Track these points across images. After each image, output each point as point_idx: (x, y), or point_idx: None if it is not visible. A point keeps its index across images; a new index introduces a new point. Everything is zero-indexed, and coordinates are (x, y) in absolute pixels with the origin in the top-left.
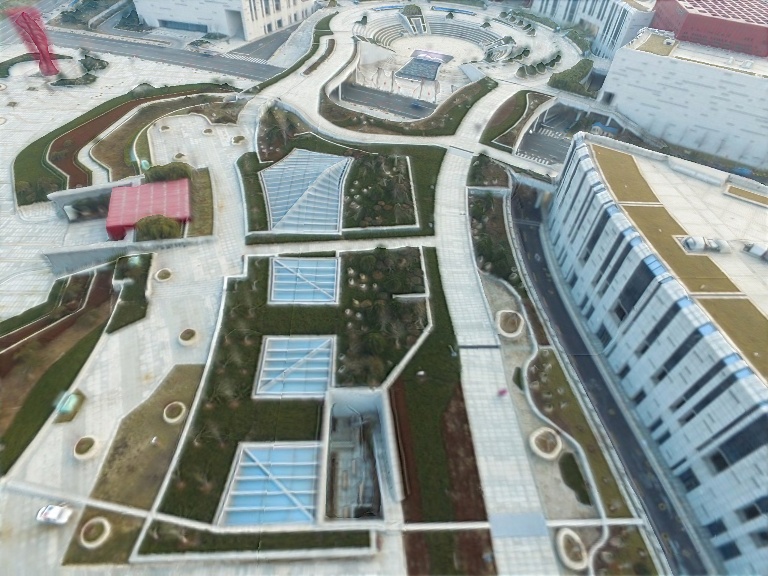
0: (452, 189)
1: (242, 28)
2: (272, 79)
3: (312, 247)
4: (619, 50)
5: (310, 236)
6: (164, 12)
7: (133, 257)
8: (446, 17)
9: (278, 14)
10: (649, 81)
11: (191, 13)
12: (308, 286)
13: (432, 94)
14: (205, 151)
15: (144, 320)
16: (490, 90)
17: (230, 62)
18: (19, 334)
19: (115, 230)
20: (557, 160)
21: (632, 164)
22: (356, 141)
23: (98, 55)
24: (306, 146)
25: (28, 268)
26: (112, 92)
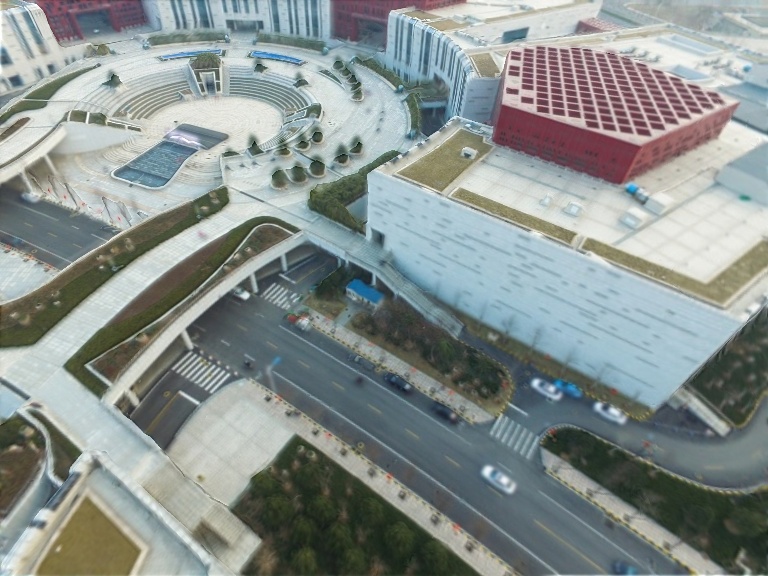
0: None
1: None
2: None
3: None
4: (370, 174)
5: None
6: None
7: None
8: (254, 70)
9: (8, 69)
10: (421, 226)
11: None
12: None
13: (123, 220)
14: None
15: None
16: (197, 221)
17: None
18: None
19: None
20: (249, 369)
21: None
22: None
23: None
24: None
25: None
26: None
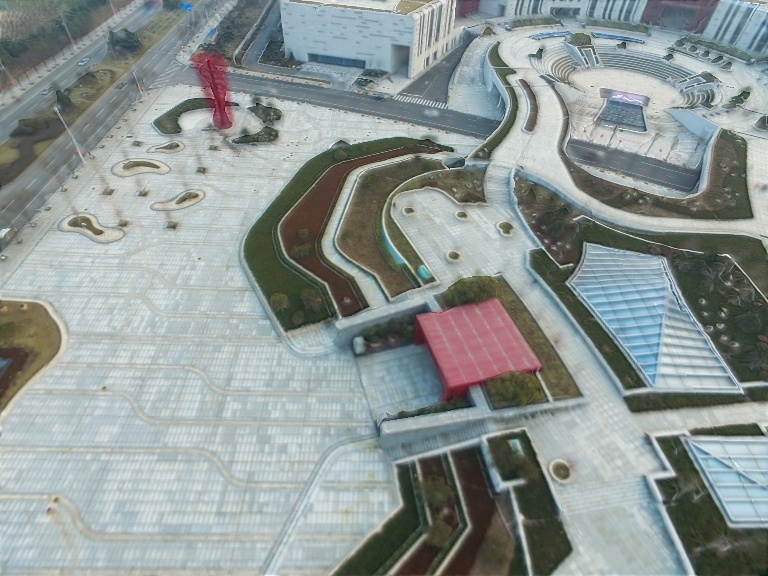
0: None
1: (407, 64)
2: (495, 138)
3: (719, 415)
4: None
5: (706, 396)
6: (317, 46)
7: (514, 443)
8: (618, 47)
9: (435, 45)
10: None
11: (350, 47)
12: (765, 492)
13: (665, 151)
14: (476, 246)
15: (574, 556)
16: (745, 149)
17: (408, 107)
18: (405, 575)
19: (458, 389)
20: None
21: None
22: (646, 229)
23: (263, 100)
24: (596, 239)
25: (342, 437)
26: (302, 151)
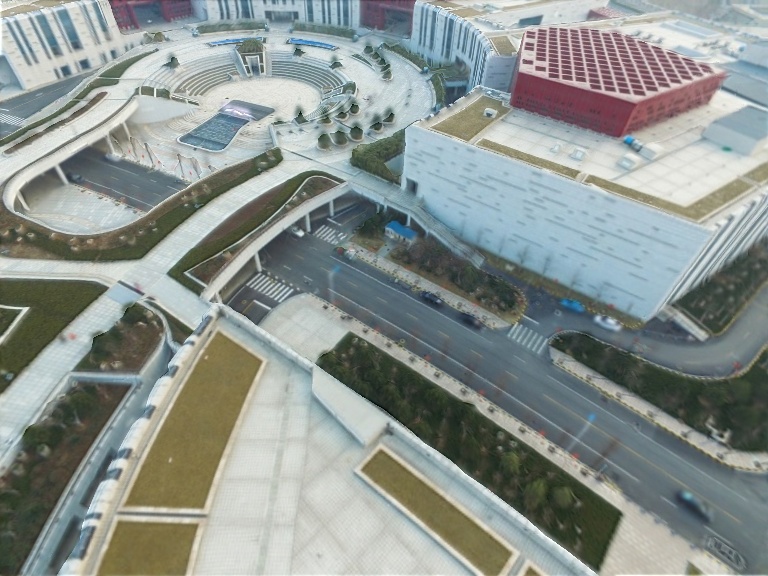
0: (43, 378)
1: (14, 75)
2: None
3: None
4: (408, 128)
5: None
6: None
7: None
8: (293, 54)
9: (79, 53)
10: (450, 171)
11: None
12: None
13: (194, 174)
14: None
15: None
16: (259, 173)
17: None
18: None
19: None
20: (308, 286)
21: (243, 386)
22: None
23: None
24: None
25: None
26: None
